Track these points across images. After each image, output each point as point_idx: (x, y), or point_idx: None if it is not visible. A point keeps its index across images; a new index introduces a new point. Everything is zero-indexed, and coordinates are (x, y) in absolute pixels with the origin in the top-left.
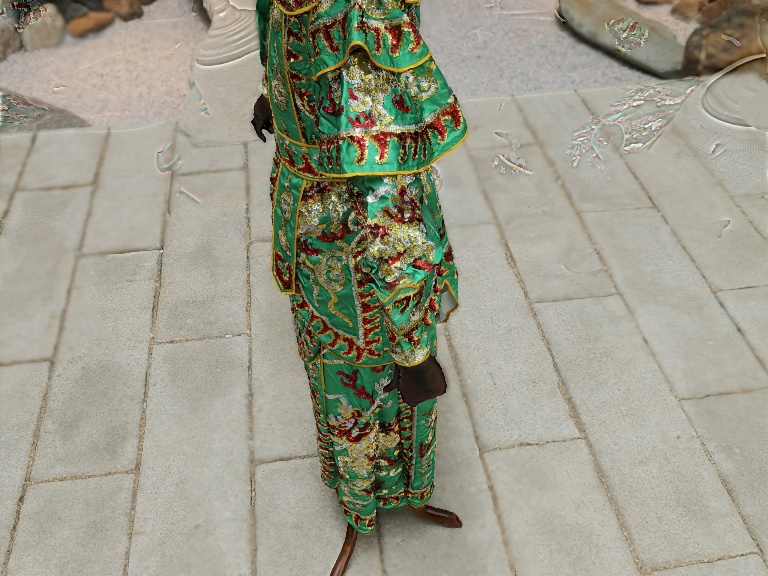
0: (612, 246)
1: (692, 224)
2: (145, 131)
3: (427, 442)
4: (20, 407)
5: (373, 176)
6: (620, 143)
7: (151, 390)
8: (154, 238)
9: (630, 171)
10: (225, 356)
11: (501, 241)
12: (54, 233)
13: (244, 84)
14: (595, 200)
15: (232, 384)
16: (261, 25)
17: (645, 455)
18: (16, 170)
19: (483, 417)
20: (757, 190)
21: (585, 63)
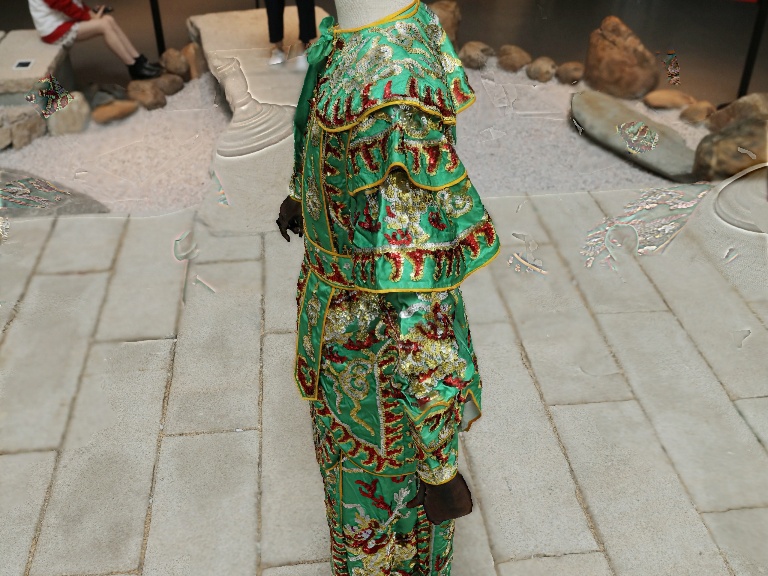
0: (628, 349)
1: (708, 329)
2: (164, 219)
3: (444, 555)
4: (23, 498)
5: (407, 292)
6: (634, 245)
7: (158, 485)
8: (168, 327)
9: (644, 273)
10: (235, 451)
11: (516, 340)
12: (69, 318)
13: (263, 176)
14: (610, 302)
15: (241, 481)
16: (298, 137)
17: (666, 572)
18: (35, 254)
19: (498, 525)
20: None
21: (596, 164)
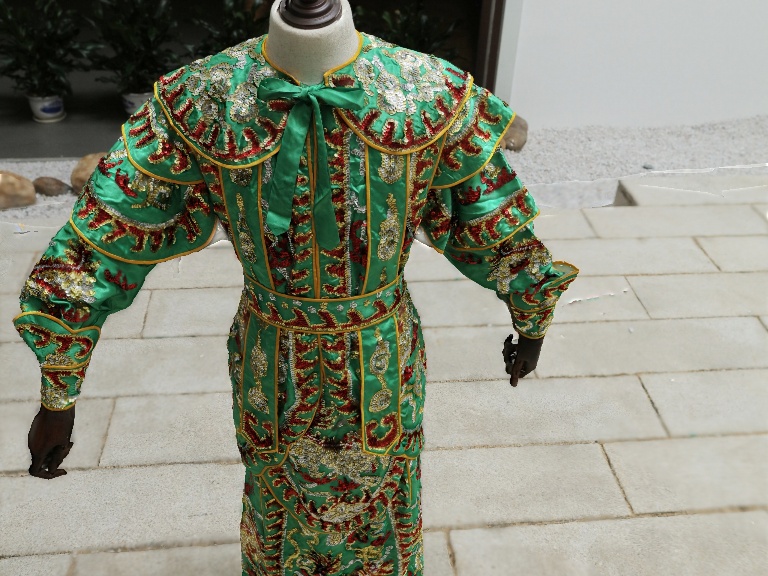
0: None
1: None
2: None
3: None
4: None
5: None
6: None
7: None
8: None
9: None
10: None
11: None
12: None
13: None
14: None
15: None
16: None
17: None
18: None
19: None
20: (19, 276)
21: None
